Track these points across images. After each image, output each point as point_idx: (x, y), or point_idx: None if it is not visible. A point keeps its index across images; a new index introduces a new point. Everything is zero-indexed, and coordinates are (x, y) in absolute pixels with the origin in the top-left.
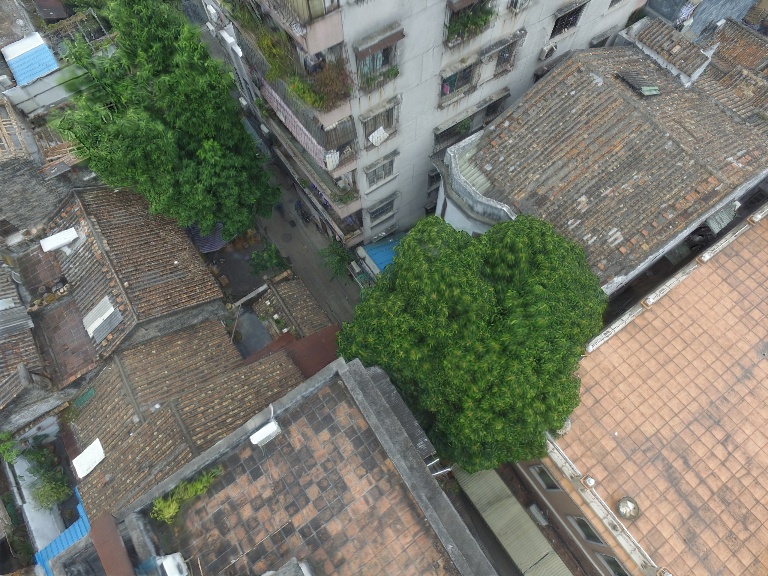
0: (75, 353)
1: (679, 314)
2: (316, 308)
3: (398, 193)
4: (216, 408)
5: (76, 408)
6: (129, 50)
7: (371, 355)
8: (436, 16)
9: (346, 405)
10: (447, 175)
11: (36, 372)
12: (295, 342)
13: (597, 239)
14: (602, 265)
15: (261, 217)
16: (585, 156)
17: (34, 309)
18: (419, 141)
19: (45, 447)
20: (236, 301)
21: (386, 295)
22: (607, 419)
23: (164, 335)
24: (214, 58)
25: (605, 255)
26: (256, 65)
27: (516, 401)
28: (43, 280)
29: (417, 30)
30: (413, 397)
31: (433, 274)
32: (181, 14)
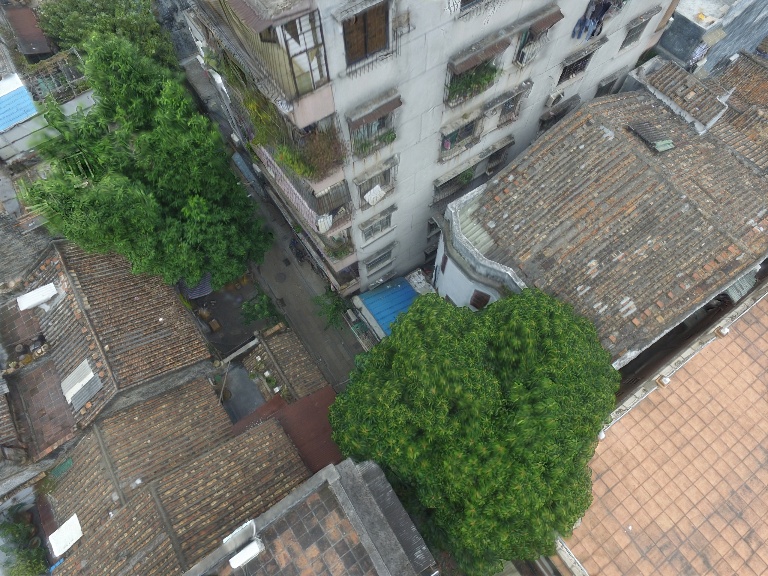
0: (53, 419)
1: (696, 389)
2: (309, 364)
3: (396, 243)
4: (200, 490)
5: (53, 479)
6: (107, 106)
7: (365, 446)
8: (436, 78)
9: (337, 514)
10: (448, 231)
11: (10, 444)
12: (286, 406)
13: (608, 308)
14: (614, 337)
15: (253, 262)
16: (595, 217)
17: (10, 371)
18: (418, 194)
19: (22, 516)
20: (225, 357)
21: (382, 373)
22: (620, 511)
23: (147, 399)
24: (206, 89)
25: (617, 326)
26: (244, 119)
27: (523, 509)
28: (21, 337)
29: (415, 93)
30: (411, 486)
31: (432, 366)
32: (170, 47)
